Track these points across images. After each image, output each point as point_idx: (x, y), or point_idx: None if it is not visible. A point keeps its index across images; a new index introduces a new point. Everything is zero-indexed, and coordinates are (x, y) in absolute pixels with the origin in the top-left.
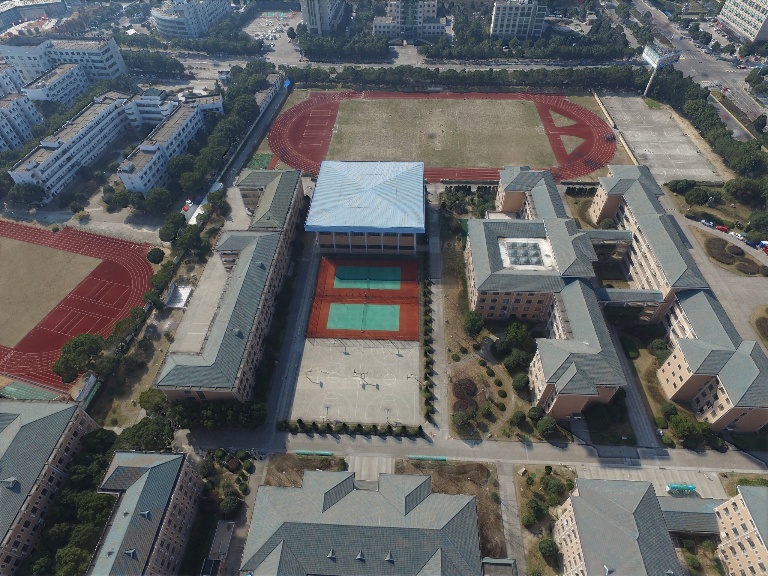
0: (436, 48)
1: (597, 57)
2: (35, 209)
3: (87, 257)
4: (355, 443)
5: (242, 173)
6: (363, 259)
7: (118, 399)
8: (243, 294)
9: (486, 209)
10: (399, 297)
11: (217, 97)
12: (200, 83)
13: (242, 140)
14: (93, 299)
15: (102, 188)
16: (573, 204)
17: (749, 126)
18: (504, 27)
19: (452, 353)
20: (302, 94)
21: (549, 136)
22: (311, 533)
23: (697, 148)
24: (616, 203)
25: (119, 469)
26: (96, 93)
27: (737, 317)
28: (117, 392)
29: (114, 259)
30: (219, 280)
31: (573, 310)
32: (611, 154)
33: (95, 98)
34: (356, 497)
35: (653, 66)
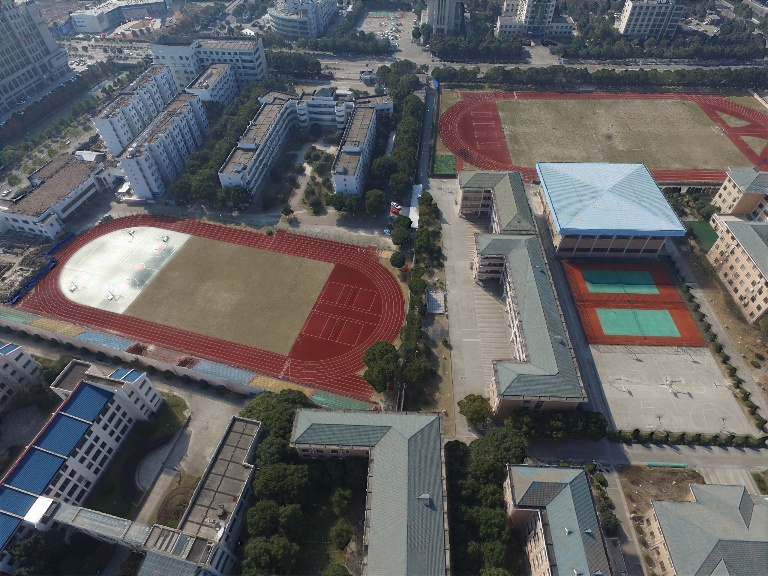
0: (575, 48)
1: (739, 57)
2: (237, 212)
3: (317, 261)
4: (698, 454)
5: (460, 175)
6: (605, 263)
7: (426, 409)
8: (543, 300)
9: (712, 211)
10: (663, 302)
11: (385, 97)
12: (341, 83)
13: None
14: (346, 304)
15: (296, 190)
16: None
17: None
18: (637, 27)
19: (749, 360)
20: (452, 94)
21: (729, 137)
22: (751, 551)
23: None
24: None
25: (535, 485)
26: (259, 93)
27: None
28: (424, 401)
29: (346, 263)
30: (466, 285)
31: None
32: None
33: (260, 98)
34: (766, 512)
35: None
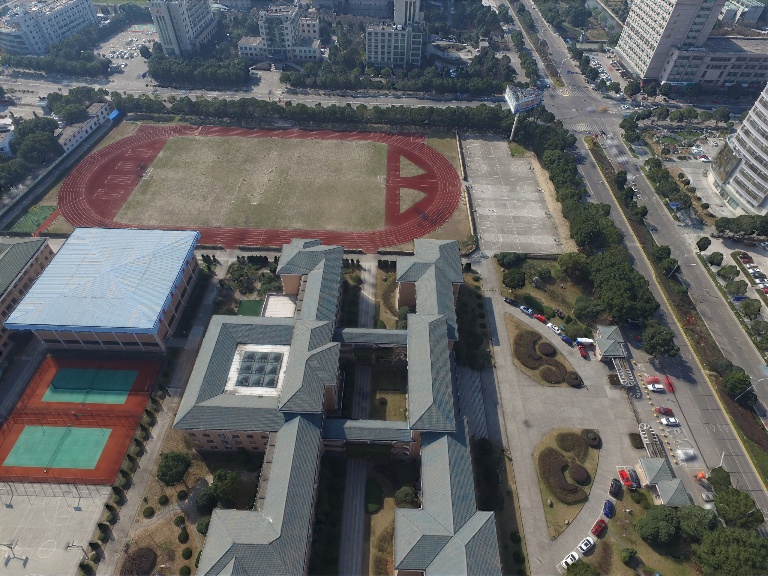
0: (297, 76)
1: (473, 92)
2: None
3: None
4: None
5: None
6: (97, 358)
7: None
8: None
9: (269, 290)
10: (116, 416)
11: (5, 134)
12: (18, 110)
13: (25, 188)
14: None
15: None
16: (381, 281)
17: (611, 181)
18: (379, 54)
19: (147, 505)
20: (129, 128)
21: (388, 189)
22: None
23: (547, 208)
24: (413, 289)
25: None
26: None
27: (520, 447)
28: None
29: None
30: None
31: (278, 463)
32: (449, 214)
33: None
34: None
35: (511, 110)
